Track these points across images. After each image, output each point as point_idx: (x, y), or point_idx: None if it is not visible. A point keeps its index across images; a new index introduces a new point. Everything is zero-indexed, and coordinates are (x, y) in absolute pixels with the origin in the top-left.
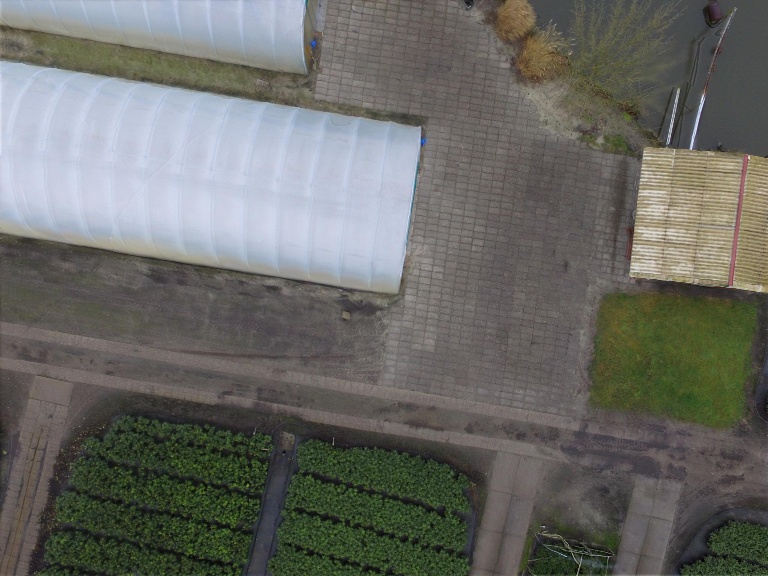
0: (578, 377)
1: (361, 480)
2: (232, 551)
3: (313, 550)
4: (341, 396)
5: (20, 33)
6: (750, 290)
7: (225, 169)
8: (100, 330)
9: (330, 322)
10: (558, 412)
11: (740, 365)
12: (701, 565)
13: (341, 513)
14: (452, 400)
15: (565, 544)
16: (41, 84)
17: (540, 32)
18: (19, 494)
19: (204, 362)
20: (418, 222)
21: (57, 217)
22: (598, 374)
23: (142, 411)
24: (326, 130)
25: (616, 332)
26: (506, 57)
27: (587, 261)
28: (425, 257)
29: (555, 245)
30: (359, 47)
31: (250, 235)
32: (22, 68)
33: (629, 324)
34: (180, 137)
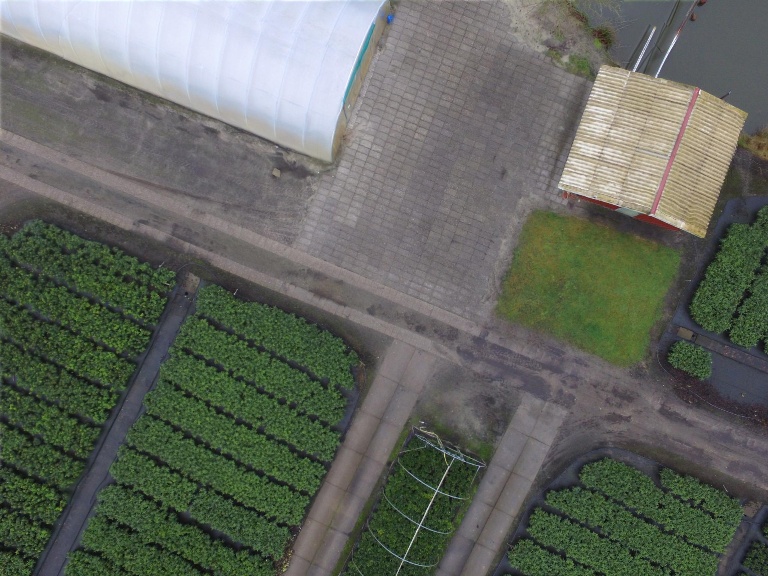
0: (490, 284)
1: (254, 335)
2: (113, 376)
3: (192, 392)
4: (253, 250)
5: None
6: (672, 225)
7: None
8: (33, 132)
9: (259, 175)
10: (462, 314)
11: (651, 308)
12: (568, 494)
13: (227, 362)
14: (361, 278)
15: (439, 442)
16: None
17: None
18: None
19: (127, 186)
20: (368, 98)
21: (10, 1)
22: (510, 285)
23: (56, 220)
24: None
25: (537, 249)
26: None
27: (525, 174)
28: (367, 133)
29: (497, 151)
30: None
31: (193, 59)
32: None
33: (552, 244)
34: None
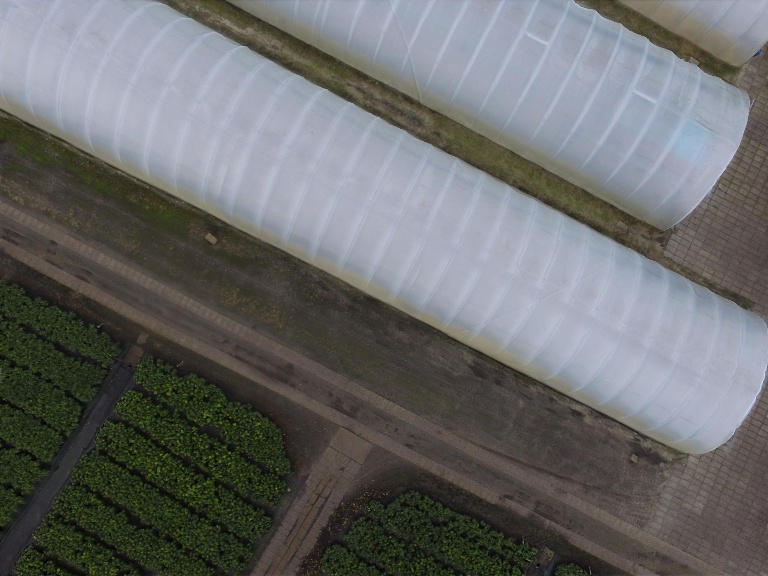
0: None
1: None
2: None
3: None
4: (608, 531)
5: (425, 110)
6: None
7: (609, 312)
8: (413, 403)
9: (618, 460)
10: None
11: None
12: None
13: None
14: (704, 564)
15: None
16: (460, 178)
17: None
18: (290, 533)
19: (497, 462)
20: None
21: (433, 300)
22: None
23: (426, 489)
24: (693, 300)
25: None
26: None
27: None
28: None
29: None
30: (714, 221)
31: (602, 373)
32: (436, 152)
33: None
34: (577, 270)
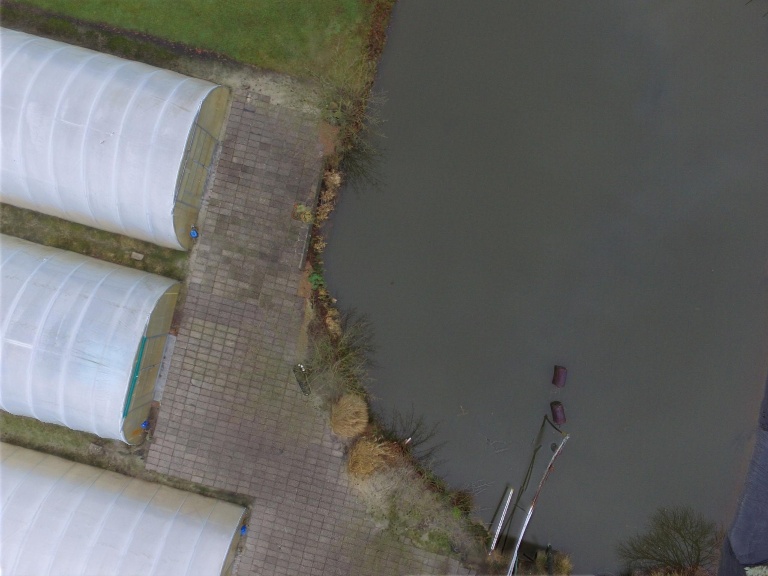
0: None
1: None
2: None
3: None
4: None
5: None
6: None
7: None
8: None
9: None
10: None
11: None
12: None
13: None
14: None
15: None
16: None
17: (365, 444)
18: None
19: None
20: None
21: None
22: None
23: None
24: (134, 537)
25: None
26: (339, 445)
27: None
28: None
29: None
30: (194, 421)
31: None
32: None
33: None
34: None
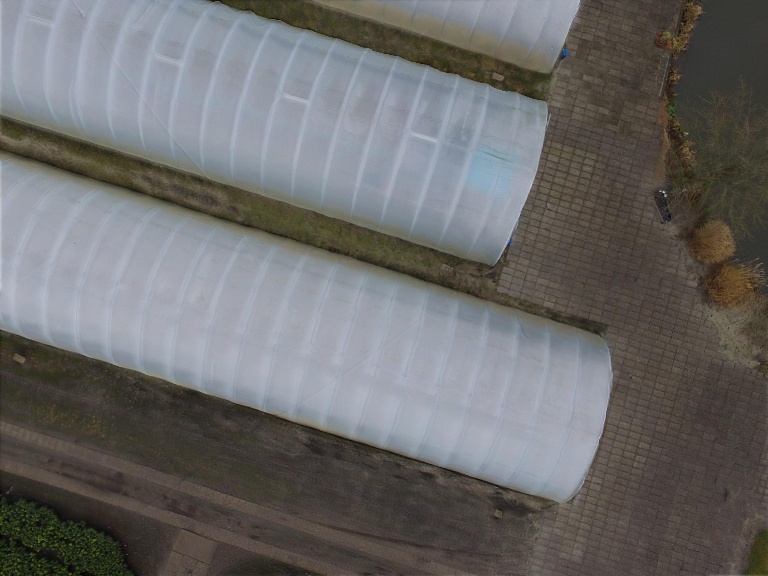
0: None
1: None
2: None
3: None
4: None
5: (216, 185)
6: None
7: (420, 377)
8: (252, 493)
9: (481, 518)
10: None
11: None
12: None
13: None
14: None
15: None
16: (244, 259)
17: (740, 266)
18: None
19: (351, 540)
20: None
21: (239, 391)
22: None
23: None
24: (519, 344)
25: None
26: (694, 276)
27: (748, 494)
28: None
29: (718, 473)
30: (548, 245)
31: (430, 440)
32: (222, 232)
33: None
34: (378, 337)
